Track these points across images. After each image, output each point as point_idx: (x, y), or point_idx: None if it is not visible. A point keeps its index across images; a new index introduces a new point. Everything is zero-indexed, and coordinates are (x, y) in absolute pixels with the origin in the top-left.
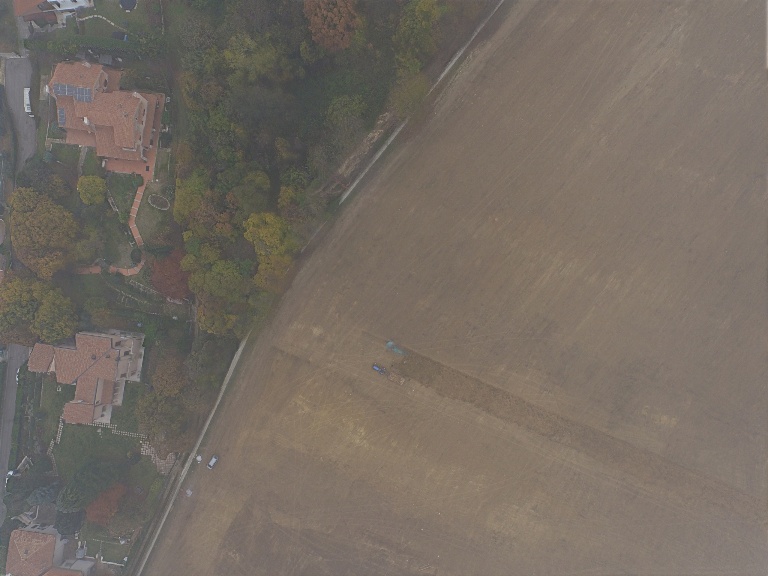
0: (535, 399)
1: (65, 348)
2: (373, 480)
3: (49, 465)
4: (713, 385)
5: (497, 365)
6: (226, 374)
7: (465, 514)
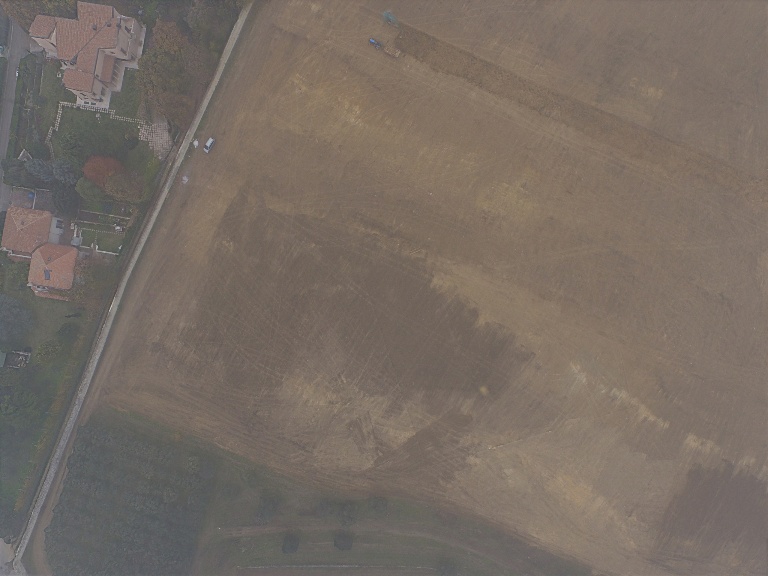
0: (527, 73)
1: (66, 18)
2: (367, 160)
3: (47, 152)
4: (699, 55)
5: (490, 39)
6: (225, 45)
7: (456, 194)
